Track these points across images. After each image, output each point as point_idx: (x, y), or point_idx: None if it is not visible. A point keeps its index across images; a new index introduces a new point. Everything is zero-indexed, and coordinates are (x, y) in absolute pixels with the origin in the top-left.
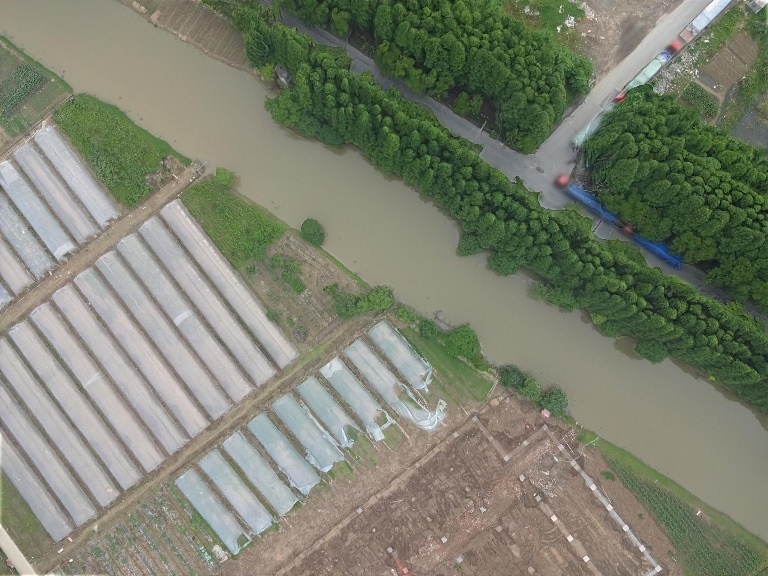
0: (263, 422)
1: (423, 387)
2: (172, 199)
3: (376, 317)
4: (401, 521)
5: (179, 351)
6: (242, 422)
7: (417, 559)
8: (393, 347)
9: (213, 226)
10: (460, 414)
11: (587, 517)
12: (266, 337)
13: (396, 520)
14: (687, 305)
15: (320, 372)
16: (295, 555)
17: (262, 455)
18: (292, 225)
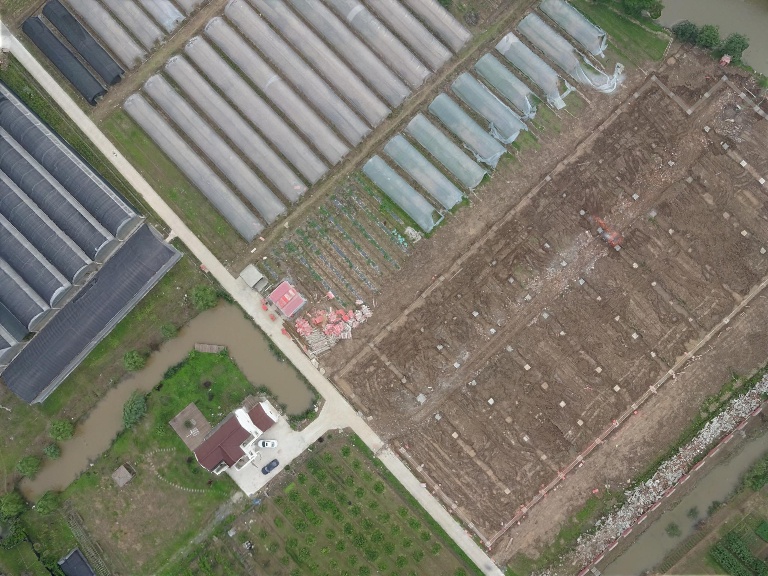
0: (446, 100)
1: (599, 53)
2: None
3: None
4: (591, 181)
5: (353, 48)
6: (422, 107)
7: (610, 218)
8: (565, 18)
9: None
10: (639, 74)
11: None
12: (438, 25)
13: (586, 182)
14: None
15: (496, 50)
16: (488, 227)
17: (446, 135)
18: None
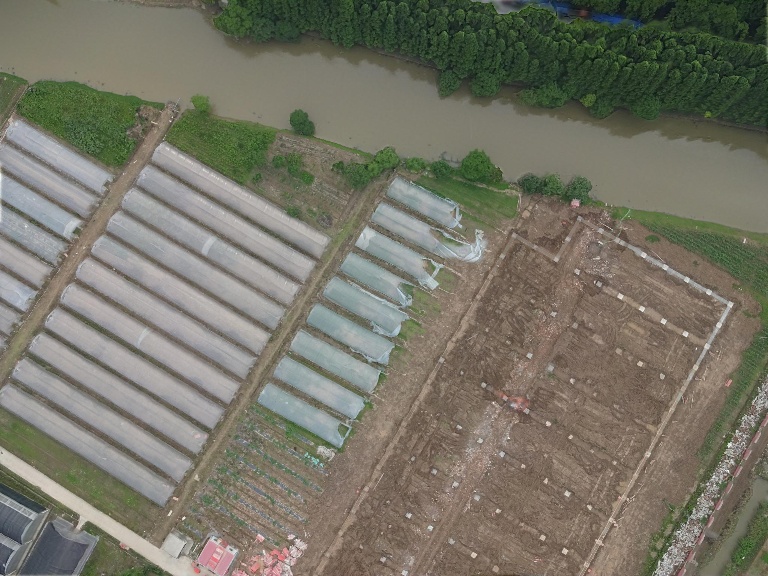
0: (321, 311)
1: (456, 225)
2: (159, 145)
3: (389, 179)
4: (484, 353)
5: (216, 280)
6: (301, 322)
7: (512, 383)
8: (415, 199)
9: (206, 154)
10: (499, 236)
11: (649, 283)
12: (294, 235)
13: (479, 355)
14: (662, 44)
15: (356, 247)
16: (397, 425)
17: (331, 344)
18: (280, 127)
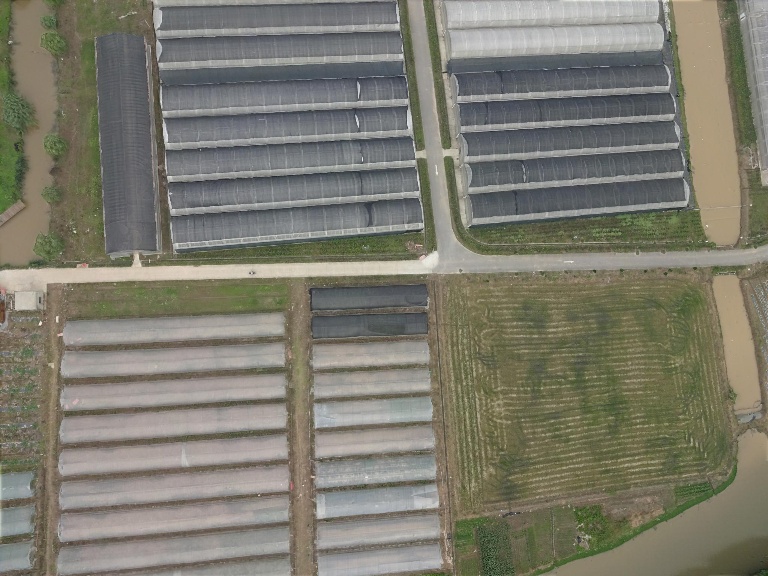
0: None
1: None
2: None
3: None
4: None
5: (152, 554)
6: (39, 573)
7: None
8: None
9: None
10: None
11: None
12: None
13: None
14: None
15: None
16: None
17: None
18: None
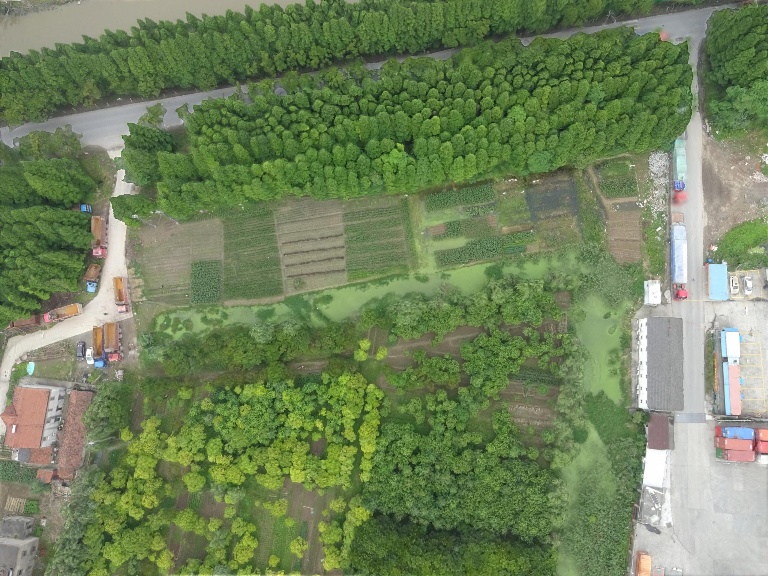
0: None
1: None
2: None
3: None
4: None
5: None
6: None
7: None
8: None
9: None
10: None
11: None
12: None
13: None
14: None
15: None
16: None
17: None
18: None
